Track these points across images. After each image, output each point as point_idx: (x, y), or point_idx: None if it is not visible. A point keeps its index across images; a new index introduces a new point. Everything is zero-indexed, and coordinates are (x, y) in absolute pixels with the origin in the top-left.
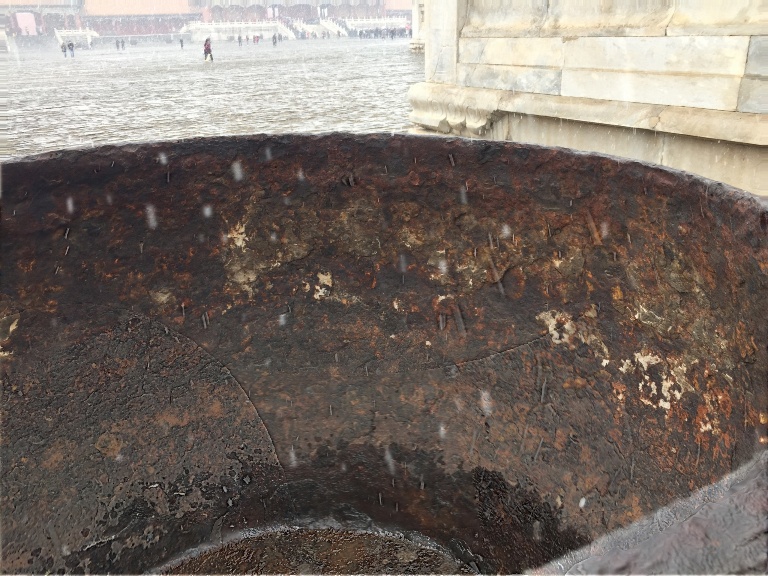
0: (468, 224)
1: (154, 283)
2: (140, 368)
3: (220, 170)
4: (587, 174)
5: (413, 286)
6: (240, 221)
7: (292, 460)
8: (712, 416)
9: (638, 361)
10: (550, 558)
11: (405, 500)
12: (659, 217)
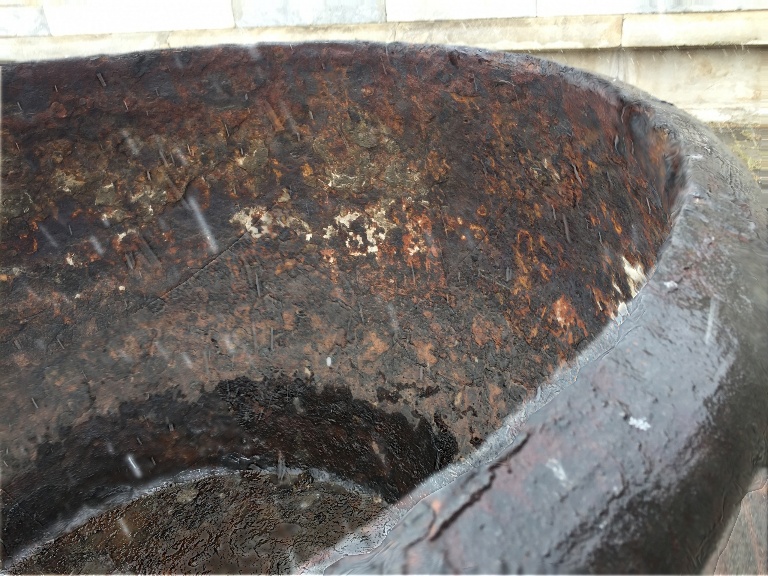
0: (134, 147)
1: None
2: None
3: None
4: (259, 64)
5: (84, 234)
6: None
7: (12, 477)
8: (417, 239)
9: (340, 223)
10: (320, 420)
11: (159, 450)
12: (340, 87)
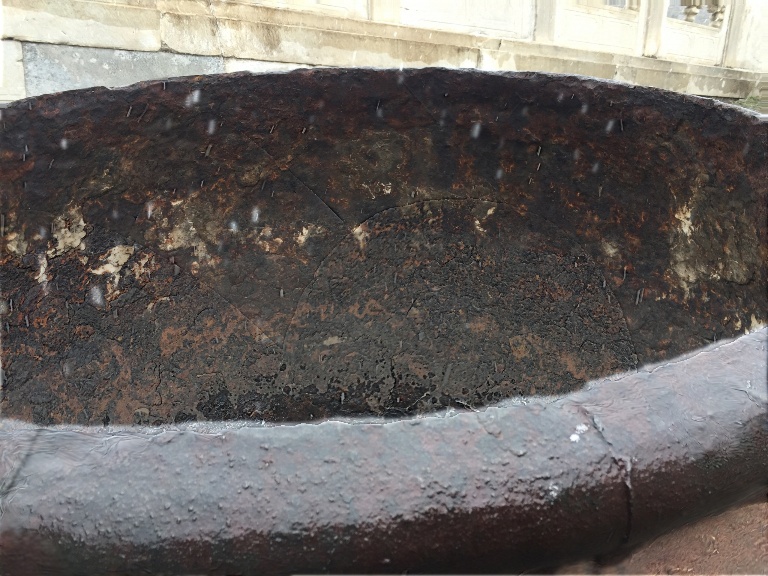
0: None
1: (608, 232)
2: (571, 303)
3: (667, 133)
4: None
5: None
6: (687, 203)
7: None
8: None
9: None
10: None
11: None
12: None
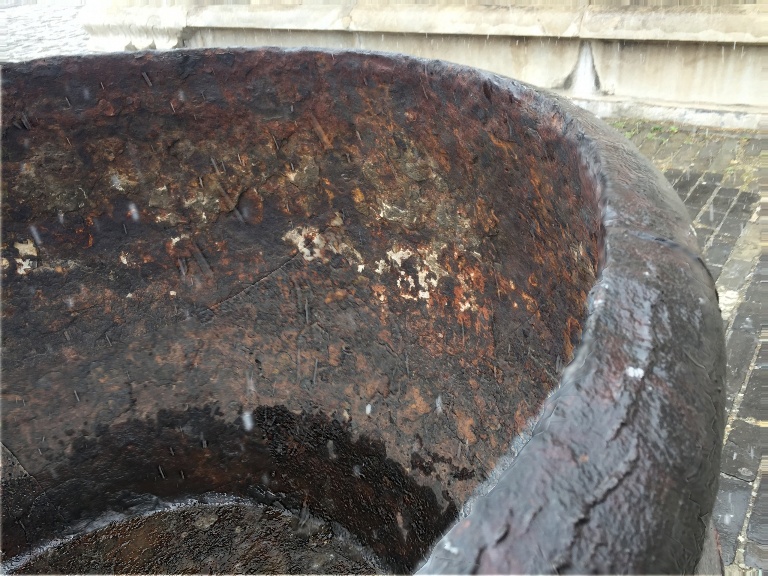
0: (185, 151)
1: None
2: None
3: None
4: (302, 73)
5: (139, 234)
6: None
7: (43, 465)
8: (468, 294)
9: (391, 259)
10: (350, 471)
11: (189, 465)
12: (384, 107)
